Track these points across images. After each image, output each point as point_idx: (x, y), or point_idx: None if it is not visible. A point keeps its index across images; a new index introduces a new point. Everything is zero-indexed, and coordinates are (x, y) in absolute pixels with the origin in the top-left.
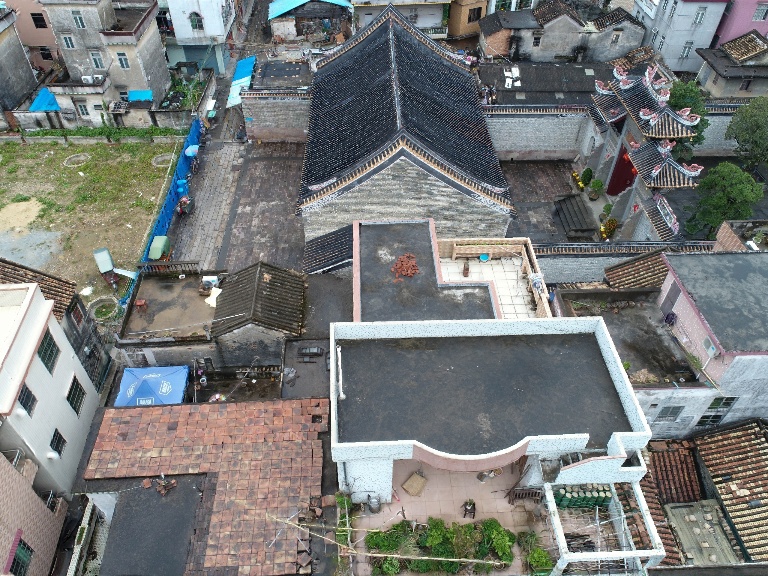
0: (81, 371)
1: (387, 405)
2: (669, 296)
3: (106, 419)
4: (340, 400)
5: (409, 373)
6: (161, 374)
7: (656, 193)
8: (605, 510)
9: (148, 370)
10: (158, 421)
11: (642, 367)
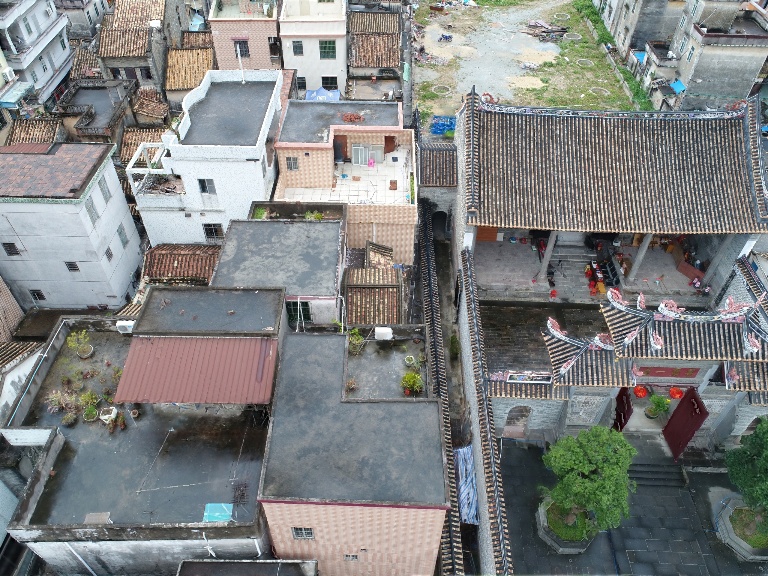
0: (343, 82)
1: (233, 93)
2: None
3: (288, 70)
4: (242, 82)
5: (251, 99)
6: (332, 97)
7: None
8: (175, 192)
9: (337, 95)
10: (283, 81)
11: None
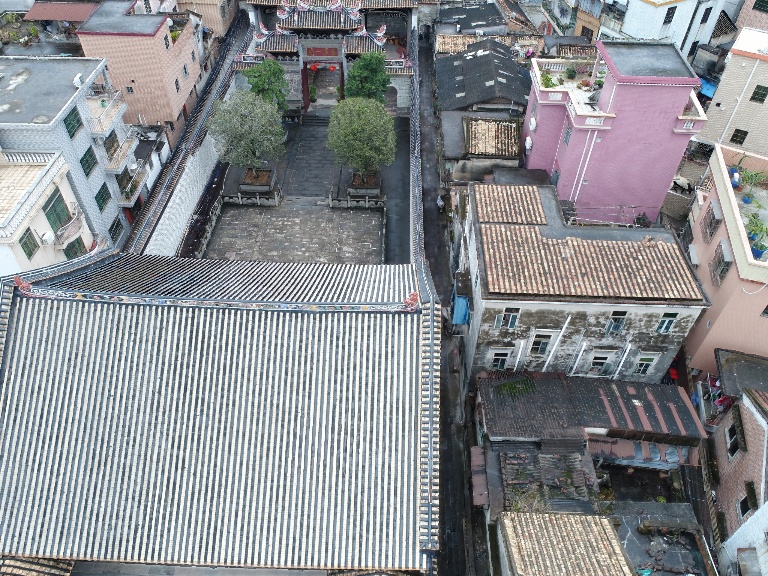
0: None
1: None
2: None
3: None
4: None
5: None
6: None
7: (273, 57)
8: None
9: None
10: None
11: None
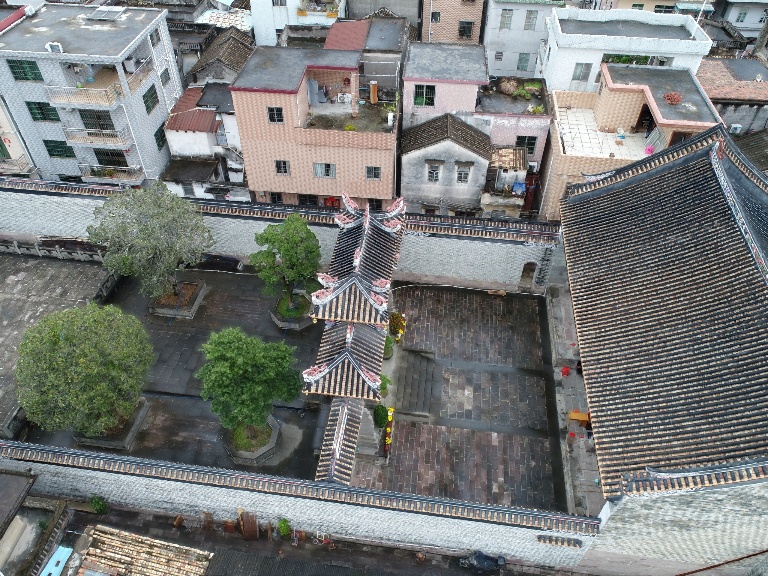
0: None
1: (668, 34)
2: (475, 103)
3: None
4: None
5: None
6: None
7: None
8: None
9: None
10: None
11: (502, 98)
